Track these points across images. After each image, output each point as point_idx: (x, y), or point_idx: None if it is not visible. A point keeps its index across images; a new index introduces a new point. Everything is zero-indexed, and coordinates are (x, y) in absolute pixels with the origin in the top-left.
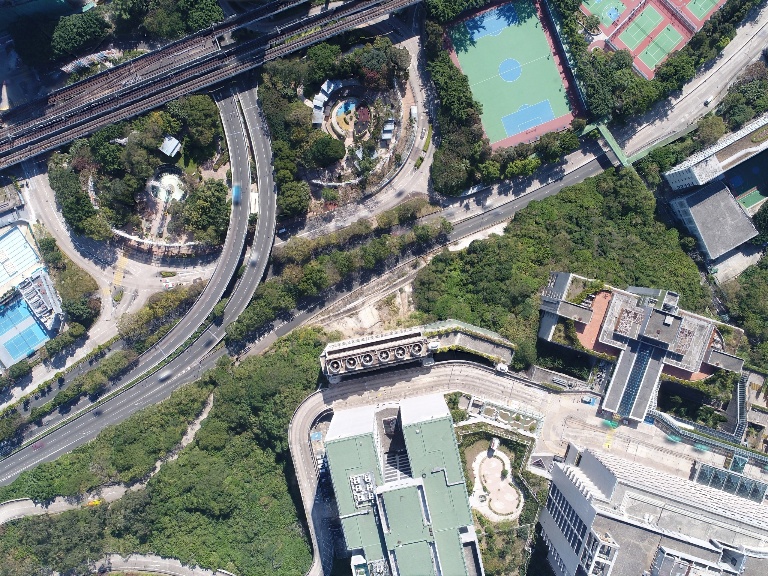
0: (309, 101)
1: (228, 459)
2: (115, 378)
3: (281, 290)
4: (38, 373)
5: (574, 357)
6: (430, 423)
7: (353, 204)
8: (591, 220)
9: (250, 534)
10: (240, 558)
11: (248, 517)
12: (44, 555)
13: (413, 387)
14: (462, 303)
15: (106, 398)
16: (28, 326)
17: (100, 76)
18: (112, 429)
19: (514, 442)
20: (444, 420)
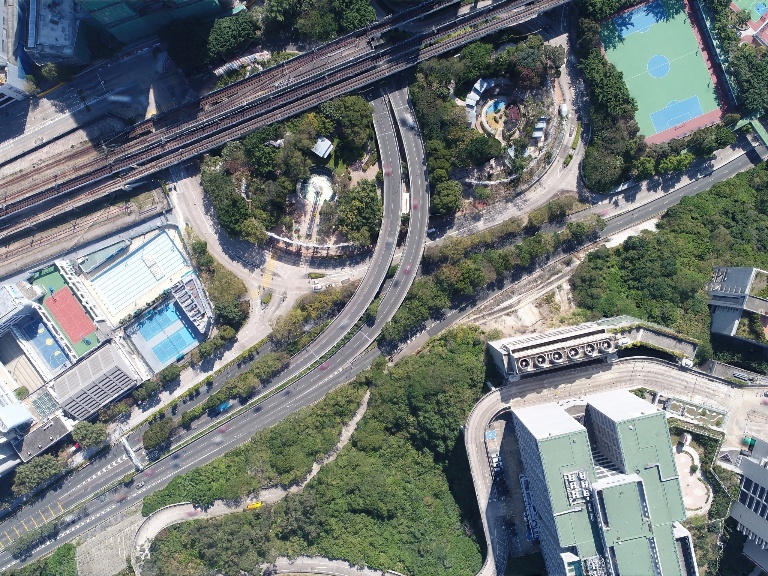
0: (459, 100)
1: (386, 460)
2: (265, 381)
3: (436, 290)
4: (186, 377)
5: (749, 351)
6: (644, 419)
7: (502, 202)
8: (747, 215)
9: (417, 534)
10: (410, 558)
11: (413, 517)
12: (210, 559)
13: (593, 384)
14: (626, 299)
15: (257, 401)
16: (176, 330)
17: (252, 78)
18: (268, 432)
19: (706, 437)
20: (658, 416)
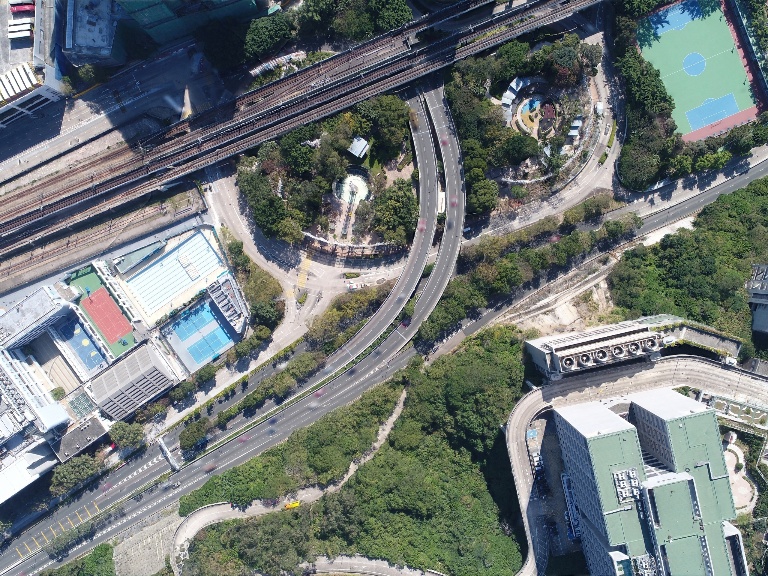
0: (495, 99)
1: (423, 459)
2: (301, 380)
3: (473, 289)
4: (221, 377)
5: None
6: (694, 417)
7: (537, 201)
8: None
9: (457, 533)
10: (449, 558)
11: (452, 516)
12: (249, 559)
13: (636, 382)
14: (665, 298)
15: (292, 400)
16: (212, 330)
17: (288, 78)
18: (305, 431)
19: (751, 435)
20: (708, 414)
